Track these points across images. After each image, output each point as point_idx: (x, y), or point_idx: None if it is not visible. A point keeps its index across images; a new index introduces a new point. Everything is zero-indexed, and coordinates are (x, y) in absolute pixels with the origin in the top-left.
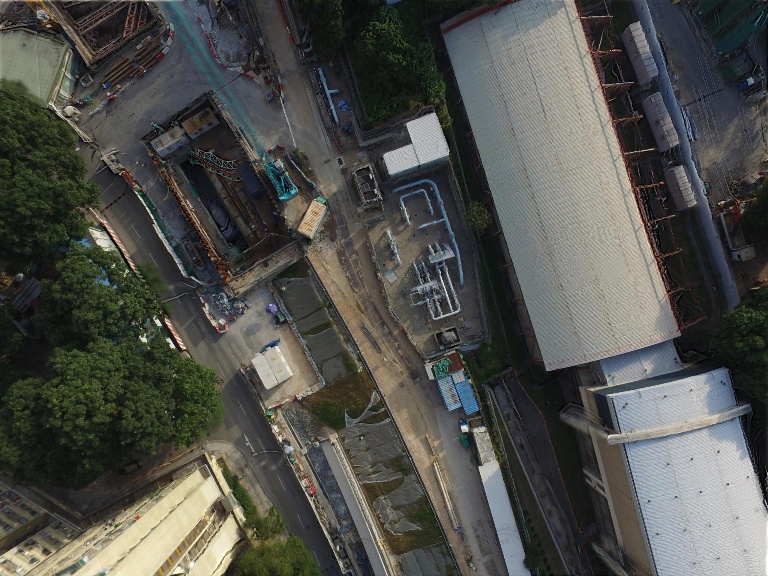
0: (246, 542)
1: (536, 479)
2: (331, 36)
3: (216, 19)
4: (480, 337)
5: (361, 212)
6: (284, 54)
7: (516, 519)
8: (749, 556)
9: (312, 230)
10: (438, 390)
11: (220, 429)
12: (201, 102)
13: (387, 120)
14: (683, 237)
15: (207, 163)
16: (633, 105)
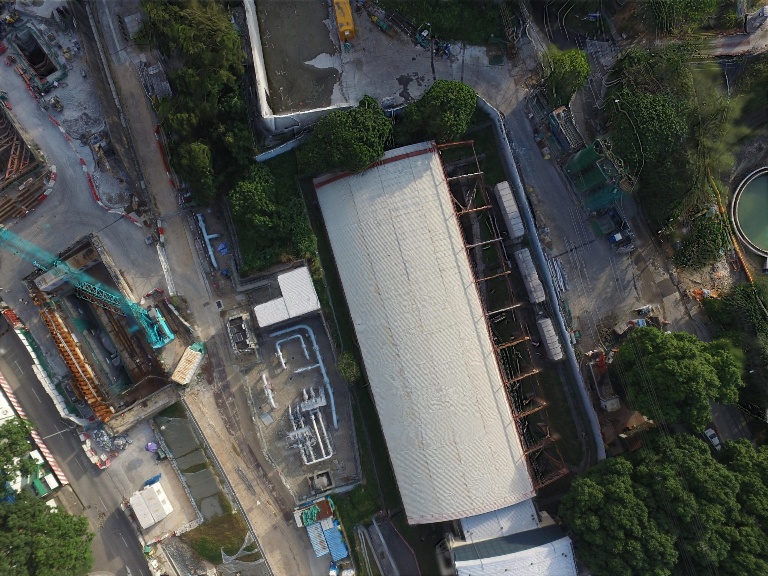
0: None
1: None
2: (203, 191)
3: (97, 163)
4: (354, 479)
5: (239, 355)
6: (165, 197)
7: None
8: None
9: (186, 378)
10: (307, 536)
11: (102, 561)
12: (83, 243)
13: (262, 269)
14: (555, 382)
15: (93, 297)
16: (507, 254)
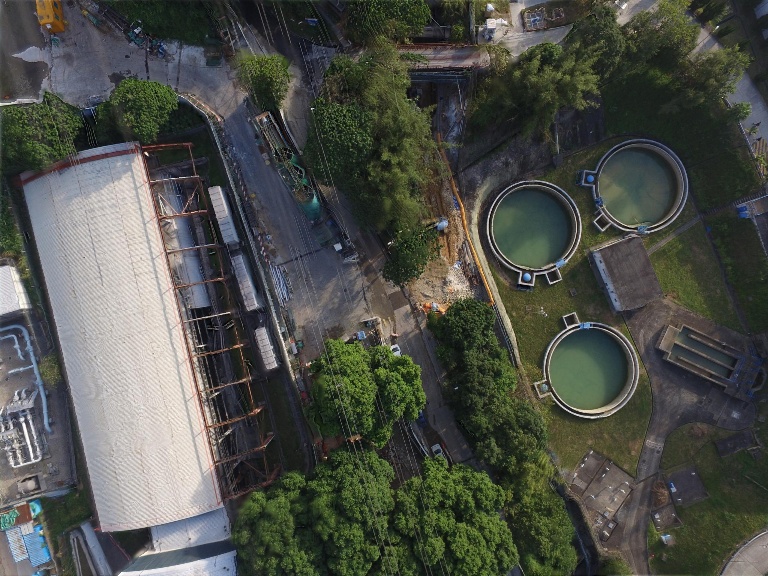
0: None
1: None
2: None
3: None
4: (68, 483)
5: None
6: None
7: None
8: None
9: None
10: None
11: None
12: None
13: None
14: (281, 391)
15: None
16: None
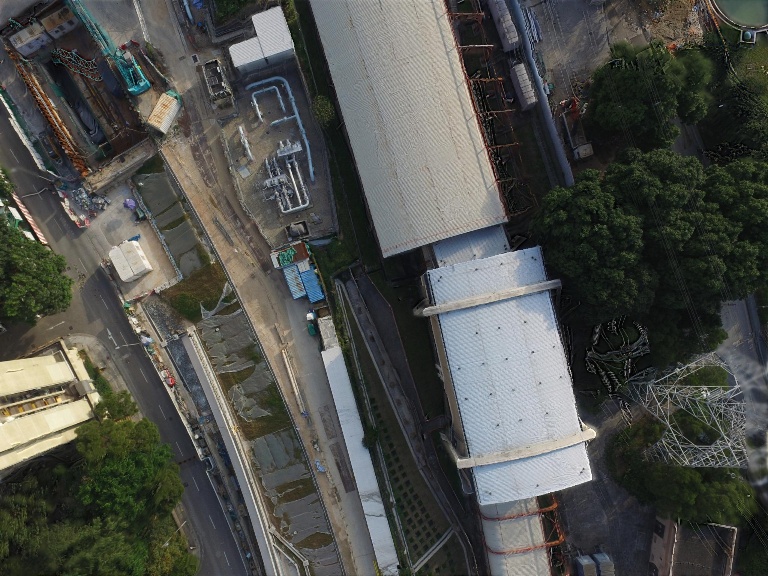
0: (95, 421)
1: (386, 370)
2: None
3: None
4: (331, 232)
5: (215, 109)
6: None
7: (358, 402)
8: (549, 418)
9: (162, 122)
10: (284, 279)
11: (83, 323)
12: None
13: (236, 15)
14: (530, 138)
15: (70, 63)
16: (481, 6)
